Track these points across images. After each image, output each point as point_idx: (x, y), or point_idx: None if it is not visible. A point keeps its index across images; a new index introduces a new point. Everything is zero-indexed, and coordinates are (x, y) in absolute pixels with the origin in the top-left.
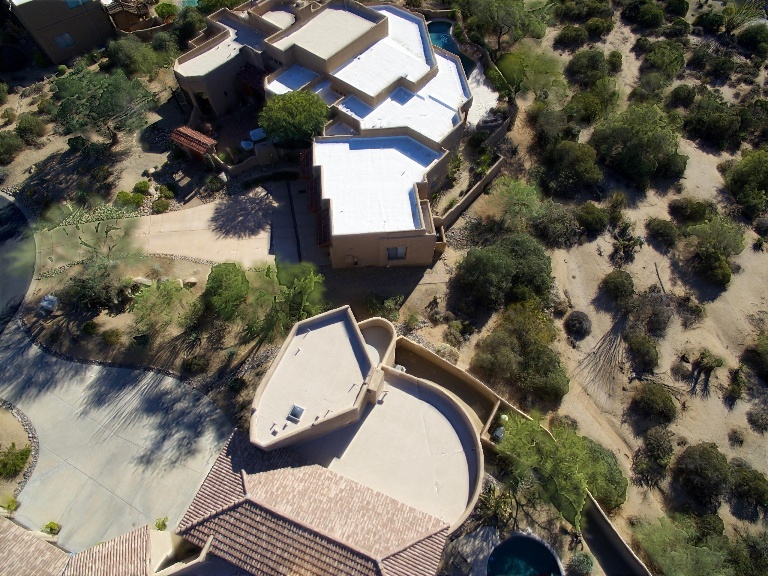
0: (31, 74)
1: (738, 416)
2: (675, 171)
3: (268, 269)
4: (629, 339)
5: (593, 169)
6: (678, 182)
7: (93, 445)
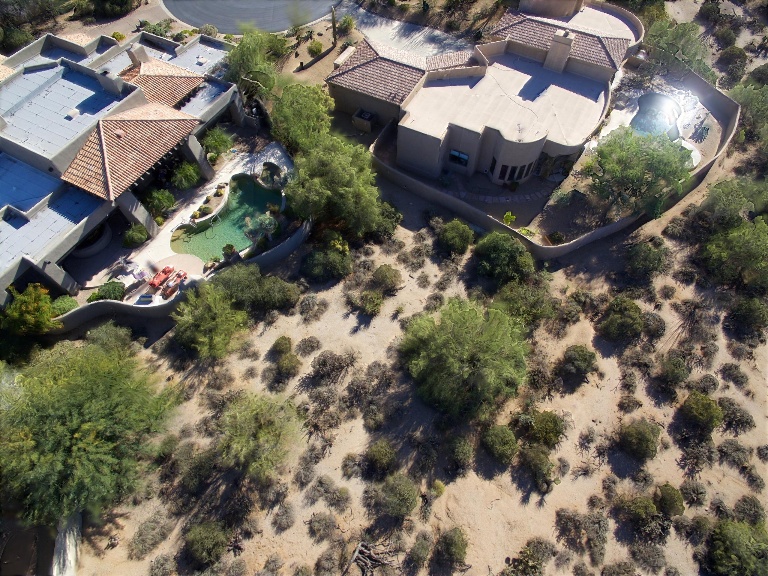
0: None
1: None
2: None
3: None
4: (717, 33)
5: None
6: None
7: None
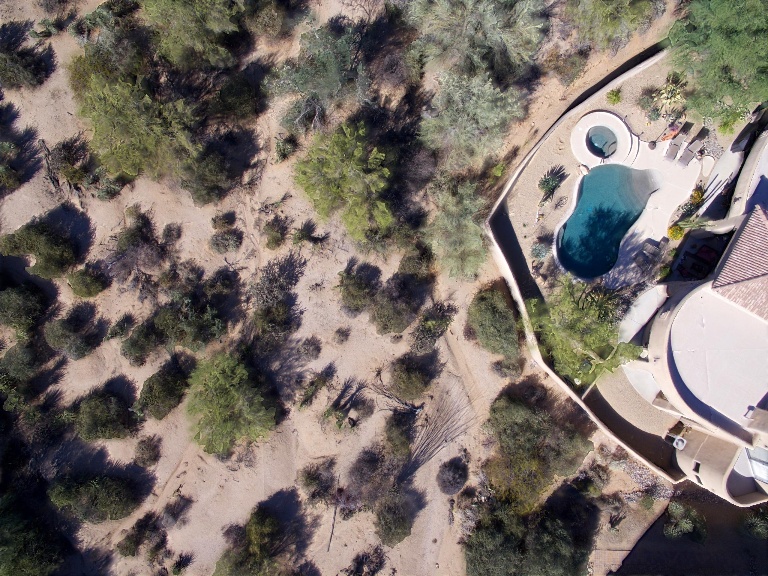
0: None
1: (328, 356)
2: None
3: None
4: None
5: None
6: None
7: None
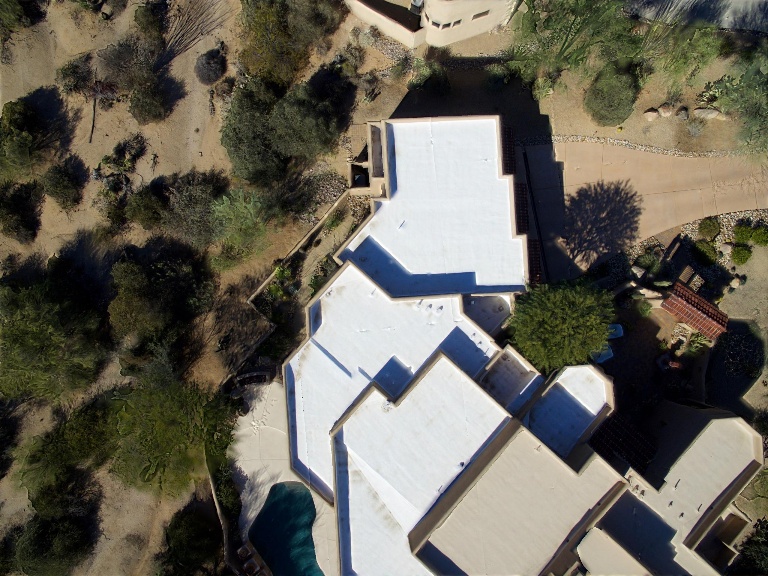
0: None
1: None
2: (4, 282)
3: None
4: None
5: (124, 277)
6: (6, 275)
7: None
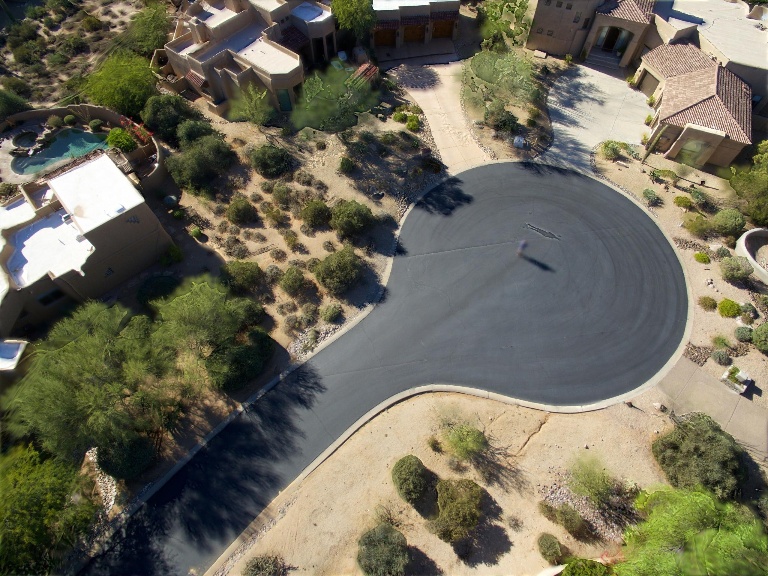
0: (194, 269)
1: None
2: None
3: (493, 17)
4: None
5: None
6: None
7: (599, 122)
